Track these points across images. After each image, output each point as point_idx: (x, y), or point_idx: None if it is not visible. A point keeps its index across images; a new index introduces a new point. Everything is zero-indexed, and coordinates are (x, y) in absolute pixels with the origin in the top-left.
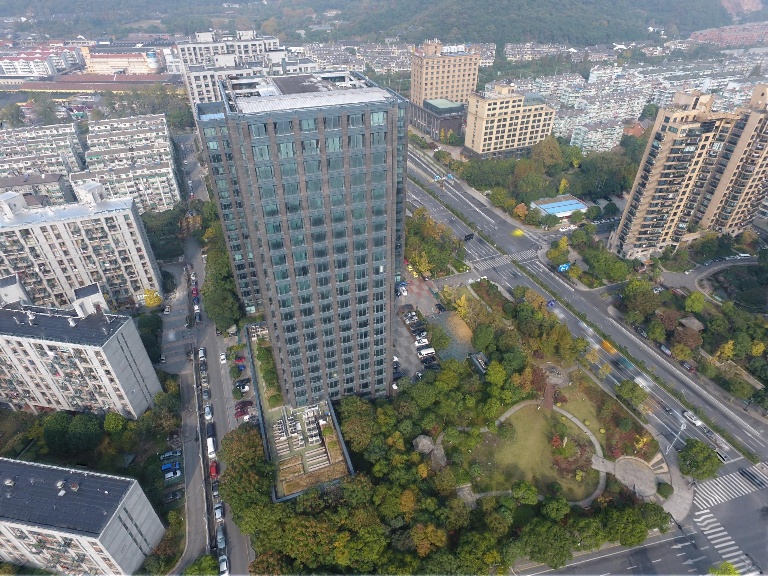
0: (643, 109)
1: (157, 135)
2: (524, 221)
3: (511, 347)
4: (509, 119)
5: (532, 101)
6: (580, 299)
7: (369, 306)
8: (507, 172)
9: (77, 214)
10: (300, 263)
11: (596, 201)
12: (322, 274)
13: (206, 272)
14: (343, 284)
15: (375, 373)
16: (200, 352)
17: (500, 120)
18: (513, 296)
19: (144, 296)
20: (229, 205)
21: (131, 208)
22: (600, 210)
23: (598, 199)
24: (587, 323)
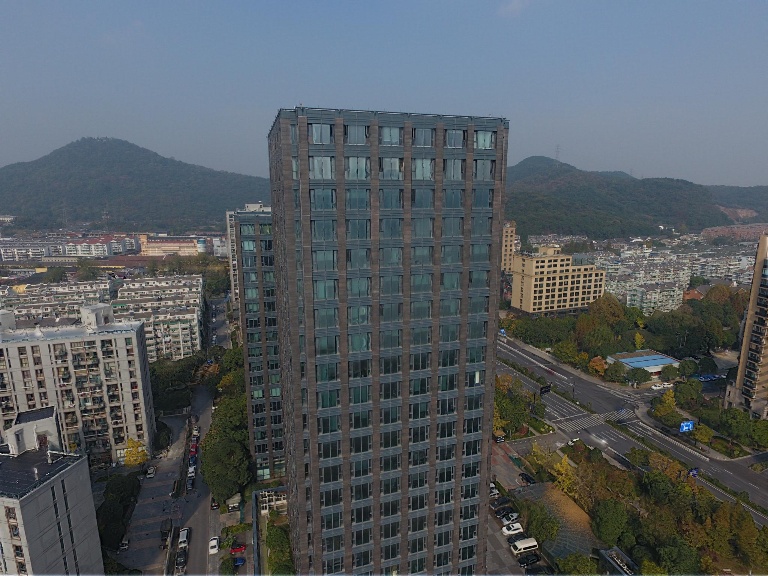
0: (690, 280)
1: (190, 291)
2: (605, 377)
3: (667, 537)
4: (558, 278)
5: (580, 261)
6: (724, 472)
7: (456, 442)
8: (567, 328)
9: (70, 335)
10: (358, 354)
11: (682, 359)
12: (389, 377)
13: (213, 420)
14: (420, 398)
15: (459, 574)
16: (182, 534)
17: (549, 278)
18: (625, 465)
19: (126, 450)
20: (256, 322)
21: (137, 330)
22: (696, 365)
23: (683, 357)
24: (754, 507)
